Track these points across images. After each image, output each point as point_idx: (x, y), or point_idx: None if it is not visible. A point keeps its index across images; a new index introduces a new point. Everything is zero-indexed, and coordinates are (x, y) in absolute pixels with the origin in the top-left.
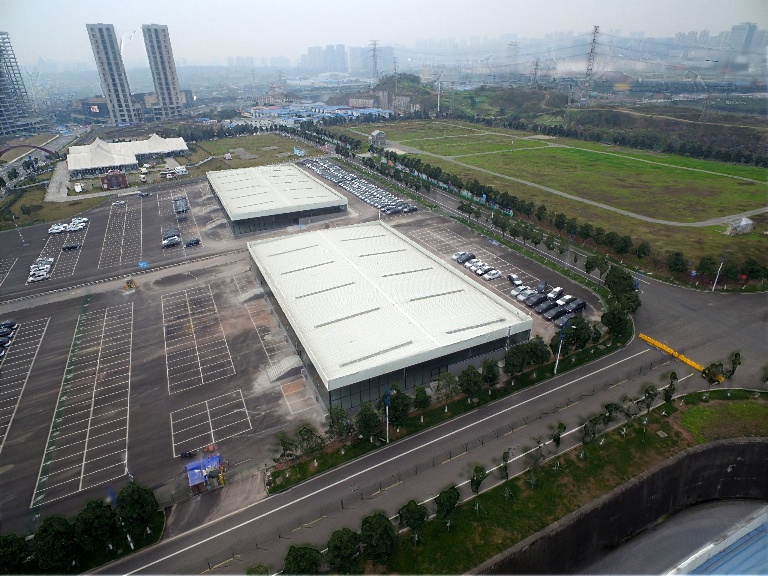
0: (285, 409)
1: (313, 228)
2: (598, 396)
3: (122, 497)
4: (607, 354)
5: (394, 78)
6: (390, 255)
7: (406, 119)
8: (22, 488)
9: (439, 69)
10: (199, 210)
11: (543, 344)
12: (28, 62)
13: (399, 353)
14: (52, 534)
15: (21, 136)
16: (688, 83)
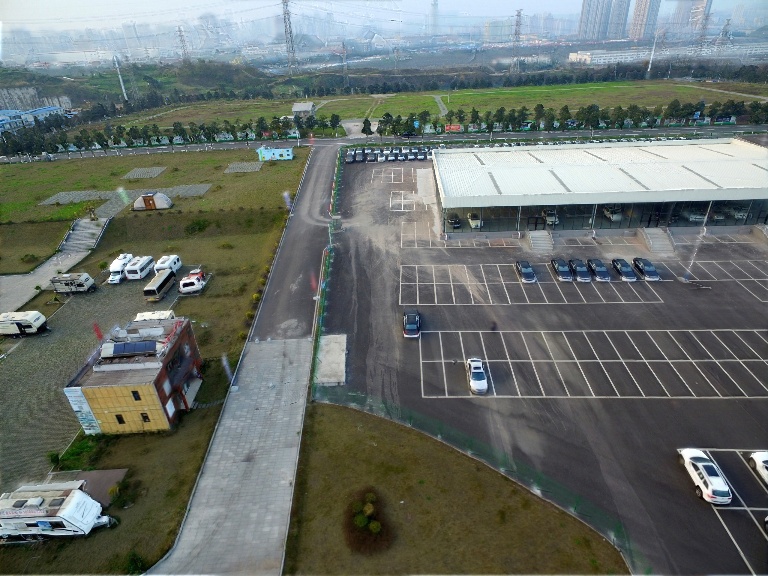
0: None
1: None
2: None
3: None
4: None
5: None
6: None
7: None
8: None
9: (27, 45)
10: (636, 254)
11: None
12: None
13: None
14: None
15: None
16: (365, 44)
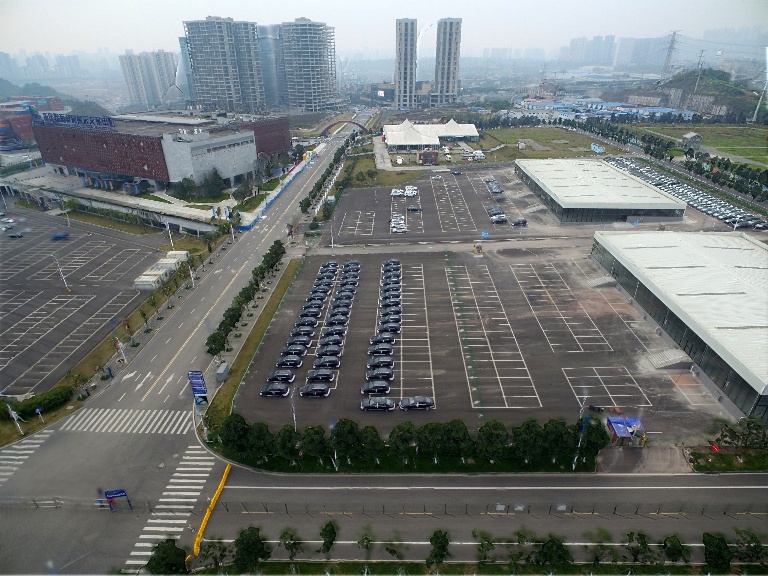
0: (683, 398)
1: (643, 228)
2: None
3: (589, 424)
4: None
5: (695, 74)
6: None
7: (713, 122)
8: (460, 390)
9: (762, 65)
10: (512, 193)
11: None
12: (343, 52)
13: None
14: (534, 433)
15: (331, 113)
16: None
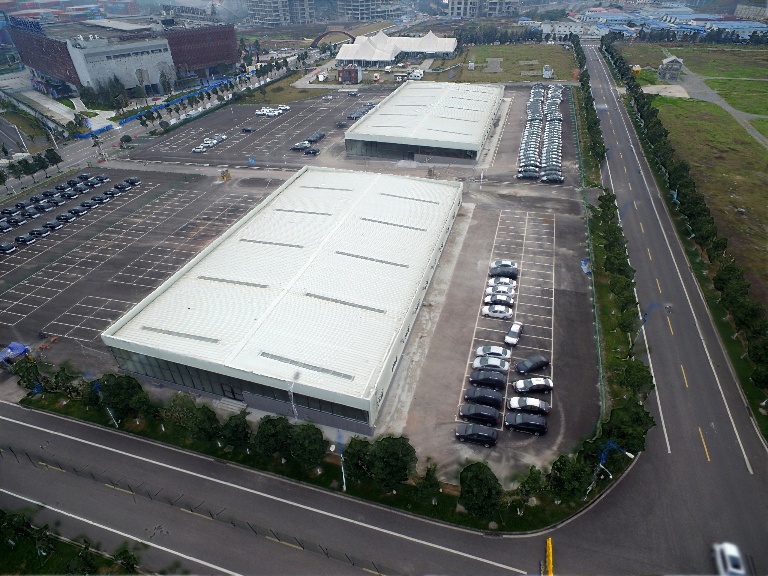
0: None
1: (421, 169)
2: (332, 564)
3: None
4: (450, 523)
5: None
6: (395, 230)
7: None
8: None
9: None
10: None
11: (305, 441)
12: None
13: (189, 346)
14: None
15: (370, 22)
16: None
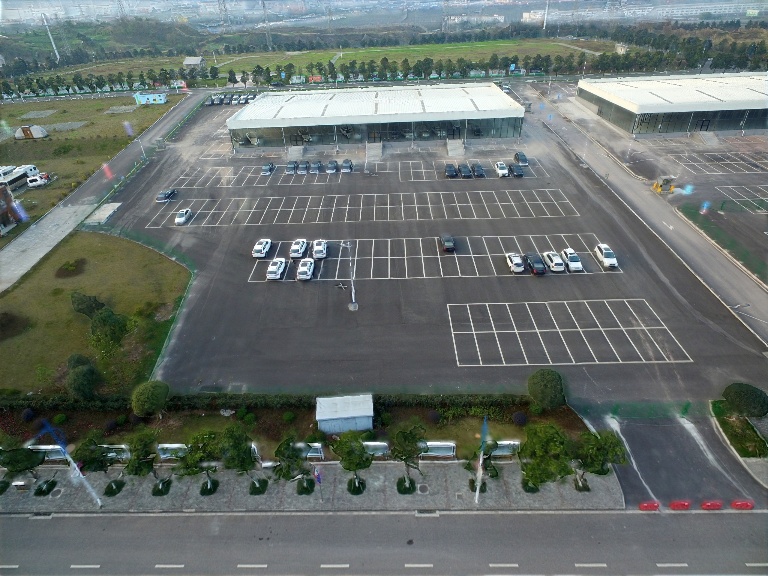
0: None
1: None
2: None
3: None
4: None
5: None
6: None
7: None
8: None
9: None
10: (354, 158)
11: None
12: None
13: None
14: None
15: None
16: (299, 3)
